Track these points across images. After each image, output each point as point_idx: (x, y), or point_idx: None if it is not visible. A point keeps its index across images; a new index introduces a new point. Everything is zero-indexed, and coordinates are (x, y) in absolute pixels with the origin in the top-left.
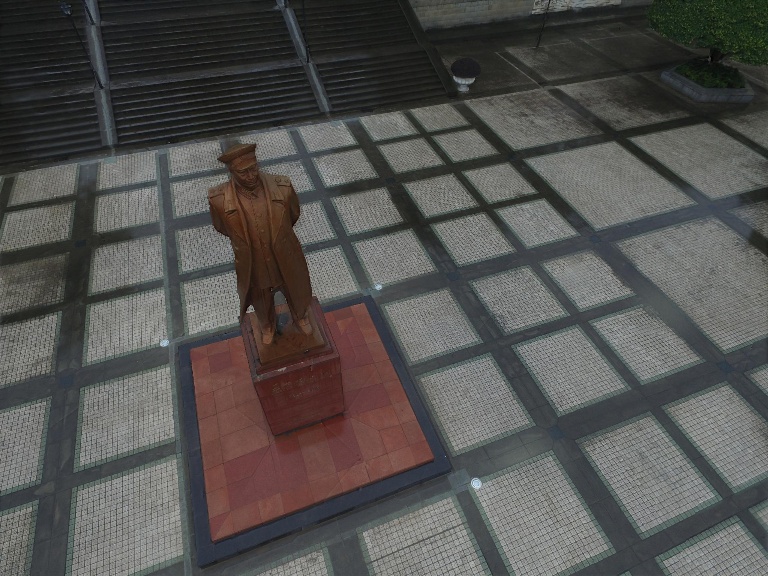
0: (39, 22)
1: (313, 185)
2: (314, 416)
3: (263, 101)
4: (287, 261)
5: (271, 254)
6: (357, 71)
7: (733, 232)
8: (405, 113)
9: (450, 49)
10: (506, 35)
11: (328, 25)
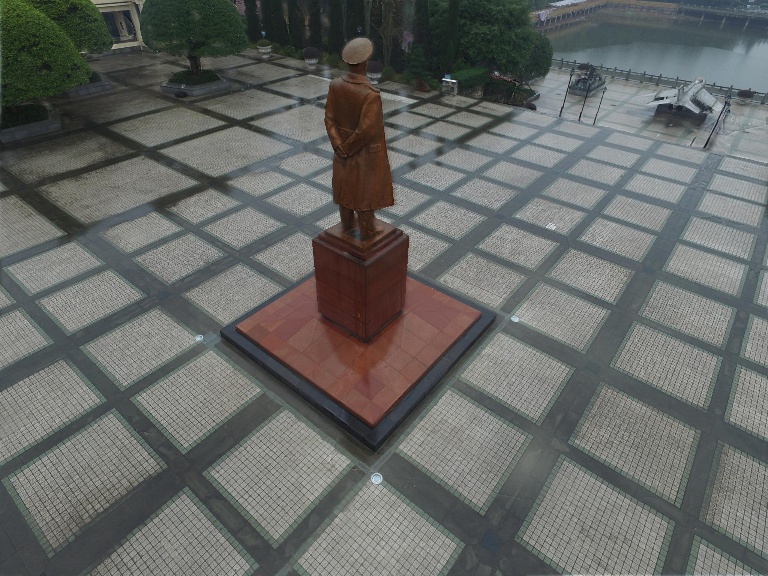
0: None
1: None
2: None
3: None
4: None
5: None
6: None
7: (60, 182)
8: None
9: None
10: None
11: None
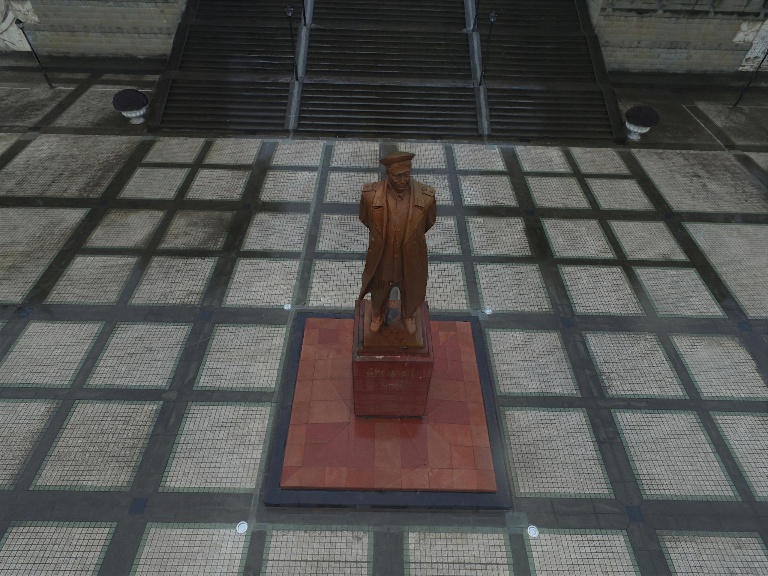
0: (265, 18)
1: (452, 200)
2: (395, 410)
3: (428, 114)
4: (412, 262)
5: (400, 252)
6: (525, 101)
7: None
8: (563, 150)
9: (631, 94)
10: (700, 88)
11: (509, 53)
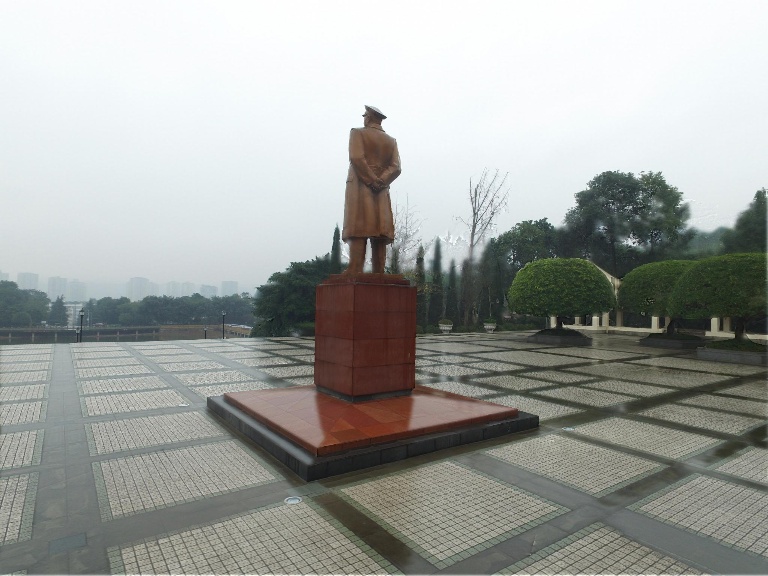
0: None
1: None
2: None
3: None
4: None
5: None
6: None
7: None
8: None
9: None
10: None
11: None
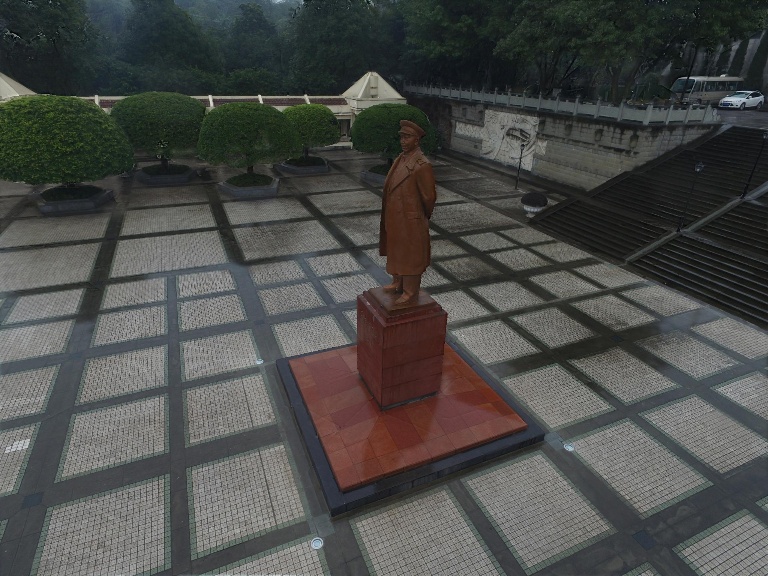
0: (708, 186)
1: (704, 377)
2: None
3: None
4: (395, 215)
5: None
6: None
7: None
8: None
9: None
10: None
11: None
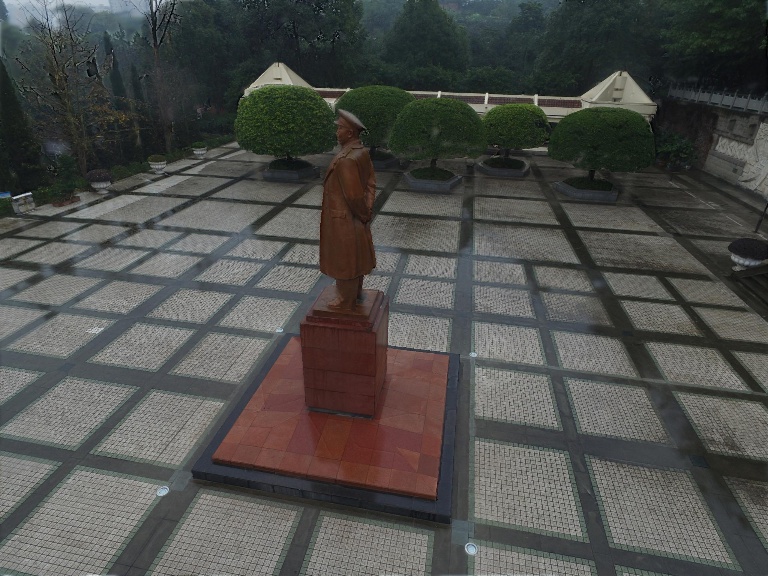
0: None
1: None
2: None
3: None
4: None
5: None
6: None
7: None
8: None
9: None
10: None
11: None
